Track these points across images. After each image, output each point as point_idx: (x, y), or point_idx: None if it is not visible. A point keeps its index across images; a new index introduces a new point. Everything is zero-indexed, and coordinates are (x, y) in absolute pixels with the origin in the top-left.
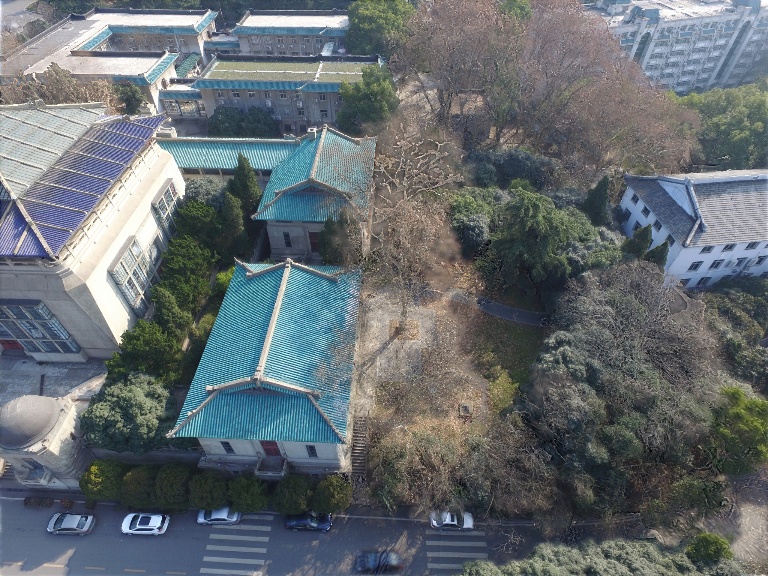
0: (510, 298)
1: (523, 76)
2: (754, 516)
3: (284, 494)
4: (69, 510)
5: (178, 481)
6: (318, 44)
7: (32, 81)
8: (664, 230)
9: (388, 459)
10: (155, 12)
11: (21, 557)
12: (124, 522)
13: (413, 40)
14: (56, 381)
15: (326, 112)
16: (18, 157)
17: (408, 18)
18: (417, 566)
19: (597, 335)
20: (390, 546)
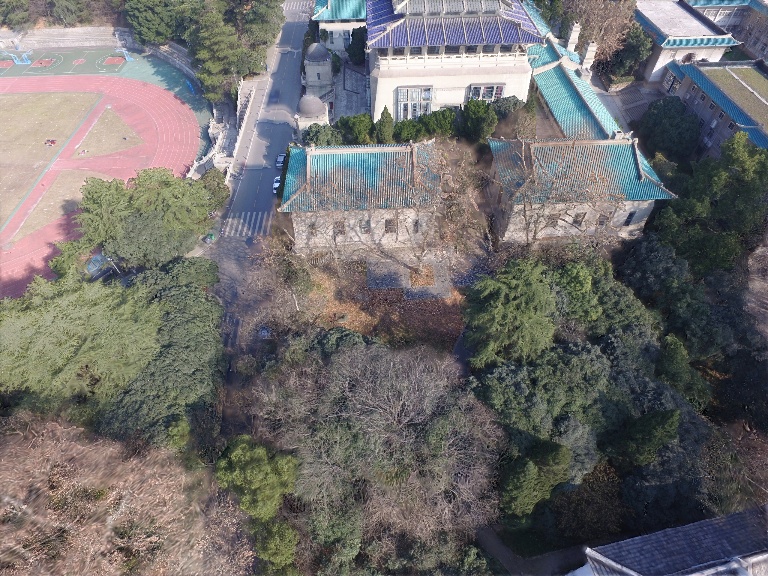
0: None
1: None
2: (192, 475)
3: None
4: None
5: None
6: None
7: (613, 2)
8: None
9: (289, 257)
10: None
11: (269, 153)
12: None
13: None
14: None
15: None
16: None
17: None
18: None
19: None
20: None
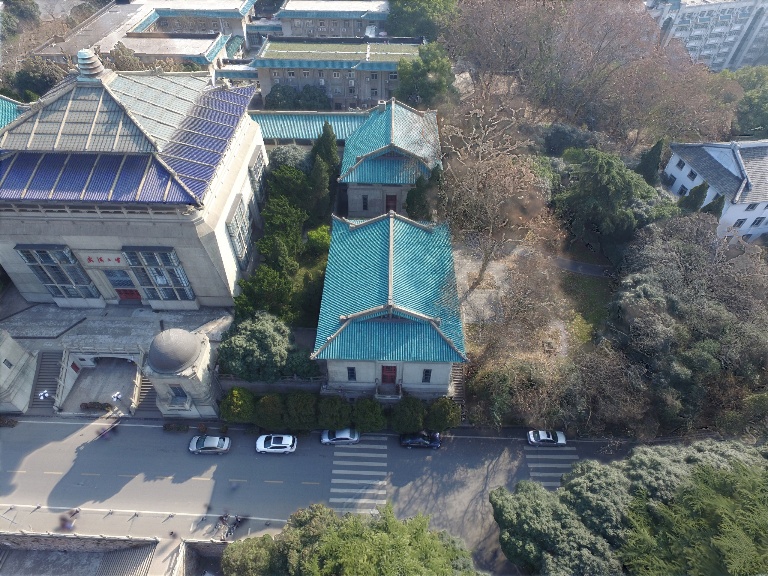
0: (573, 253)
1: None
2: None
3: (405, 412)
4: (204, 434)
5: (310, 403)
6: (358, 28)
7: None
8: (712, 191)
9: (494, 382)
10: None
11: (170, 472)
12: (258, 442)
13: (458, 22)
14: (175, 326)
15: (376, 90)
16: (153, 116)
17: (447, 2)
18: (521, 475)
19: (669, 275)
20: (495, 459)
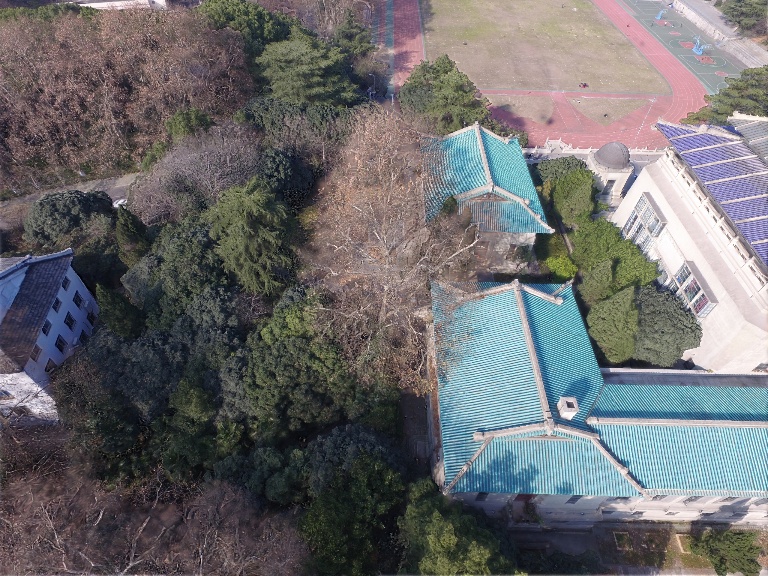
0: None
1: None
2: None
3: None
4: None
5: None
6: None
7: None
8: None
9: None
10: None
11: None
12: None
13: None
14: None
15: None
16: None
17: None
18: None
19: None
20: None
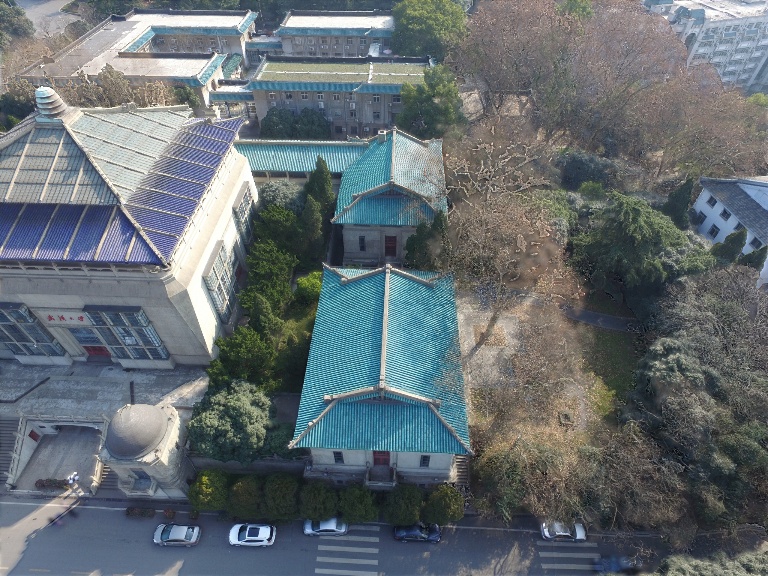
0: (592, 303)
1: (575, 77)
2: None
3: (399, 505)
4: (172, 520)
5: (290, 492)
6: (362, 45)
7: None
8: (748, 234)
9: None
10: (195, 13)
11: (130, 569)
12: (231, 533)
13: (467, 41)
14: (146, 388)
15: (379, 114)
16: (120, 161)
17: (455, 19)
18: None
19: (706, 342)
20: (503, 558)
